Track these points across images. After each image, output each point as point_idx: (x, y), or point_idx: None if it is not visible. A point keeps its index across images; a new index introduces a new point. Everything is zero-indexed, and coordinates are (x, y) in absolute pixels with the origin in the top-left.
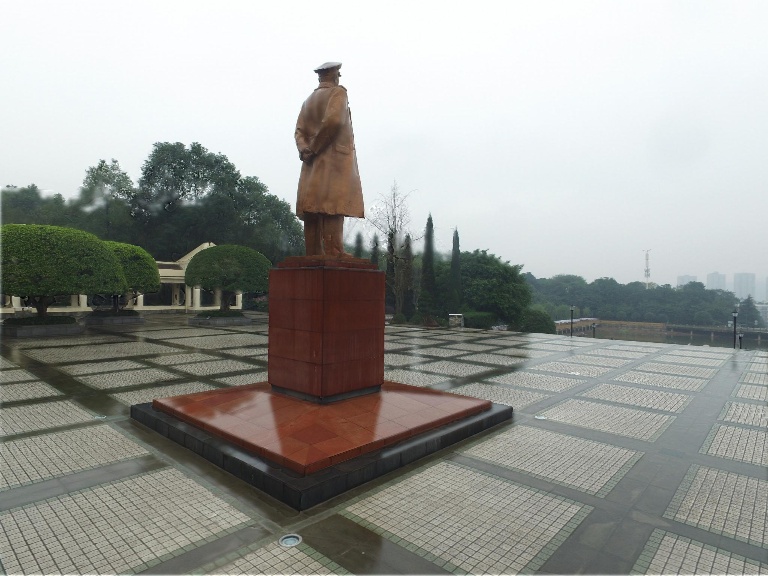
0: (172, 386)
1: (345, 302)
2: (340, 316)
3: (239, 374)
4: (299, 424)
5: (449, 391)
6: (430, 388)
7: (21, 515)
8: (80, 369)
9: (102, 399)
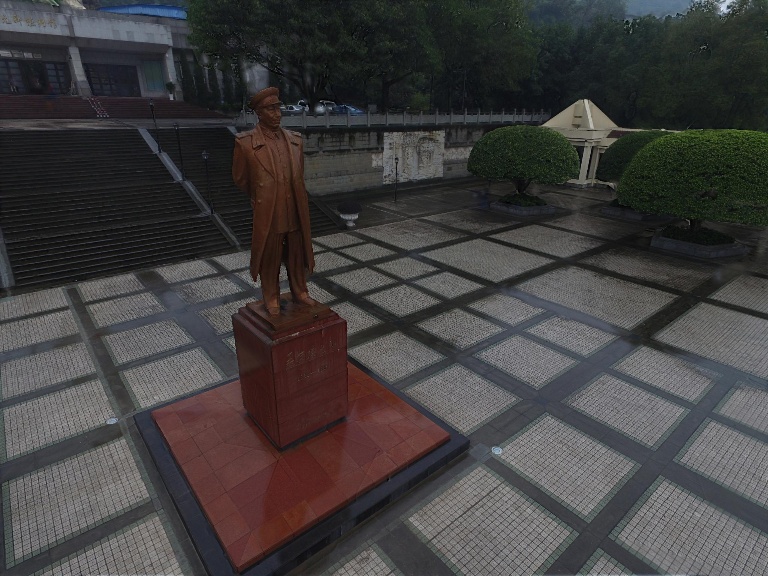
0: (425, 349)
1: (246, 351)
2: (245, 360)
3: (485, 375)
4: (214, 405)
5: (391, 572)
6: (414, 550)
7: (196, 354)
8: (491, 303)
9: (383, 331)
